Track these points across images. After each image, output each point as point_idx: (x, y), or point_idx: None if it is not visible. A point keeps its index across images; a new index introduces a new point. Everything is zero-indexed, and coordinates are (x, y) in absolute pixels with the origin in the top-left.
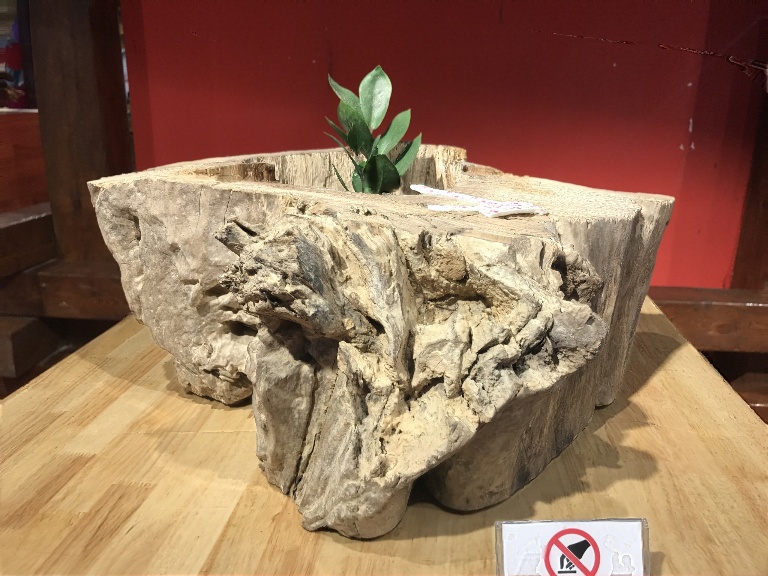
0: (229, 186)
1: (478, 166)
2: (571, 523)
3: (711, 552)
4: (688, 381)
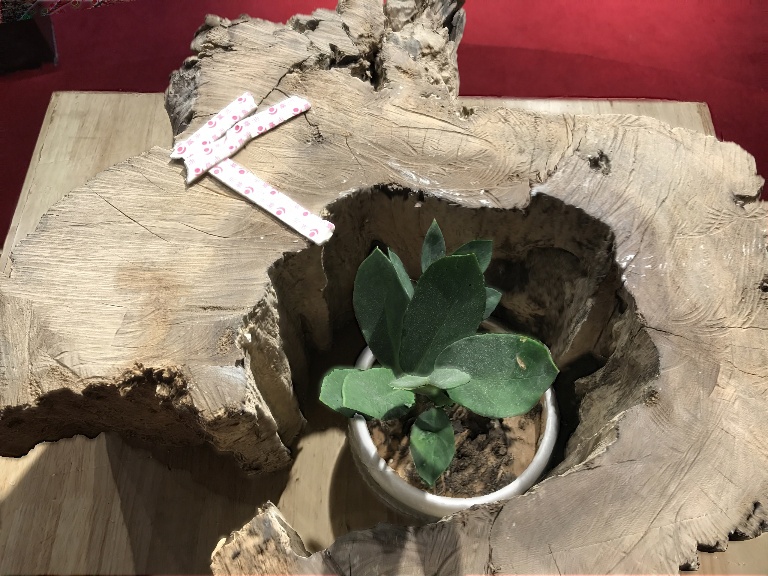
0: (549, 128)
1: (213, 366)
2: None
3: None
4: None
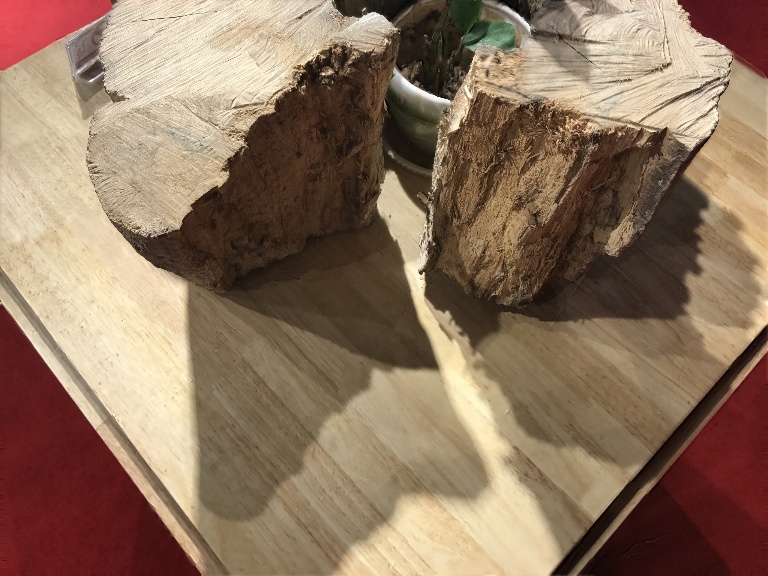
0: None
1: (352, 24)
2: (100, 19)
3: (59, 139)
4: (150, 377)
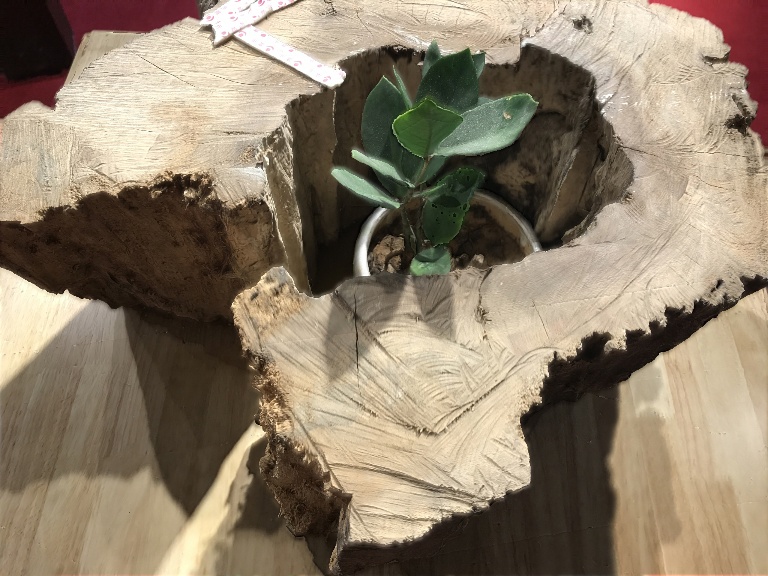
0: (538, 3)
1: (236, 168)
2: None
3: None
4: (20, 325)
